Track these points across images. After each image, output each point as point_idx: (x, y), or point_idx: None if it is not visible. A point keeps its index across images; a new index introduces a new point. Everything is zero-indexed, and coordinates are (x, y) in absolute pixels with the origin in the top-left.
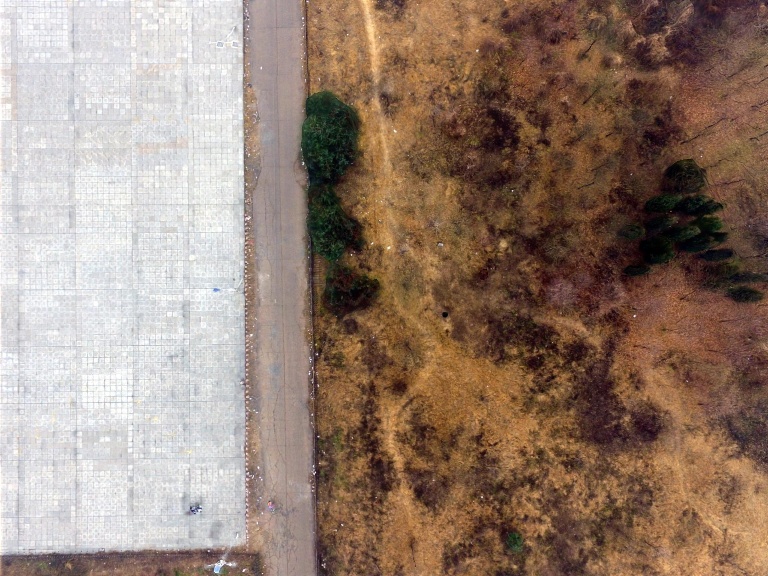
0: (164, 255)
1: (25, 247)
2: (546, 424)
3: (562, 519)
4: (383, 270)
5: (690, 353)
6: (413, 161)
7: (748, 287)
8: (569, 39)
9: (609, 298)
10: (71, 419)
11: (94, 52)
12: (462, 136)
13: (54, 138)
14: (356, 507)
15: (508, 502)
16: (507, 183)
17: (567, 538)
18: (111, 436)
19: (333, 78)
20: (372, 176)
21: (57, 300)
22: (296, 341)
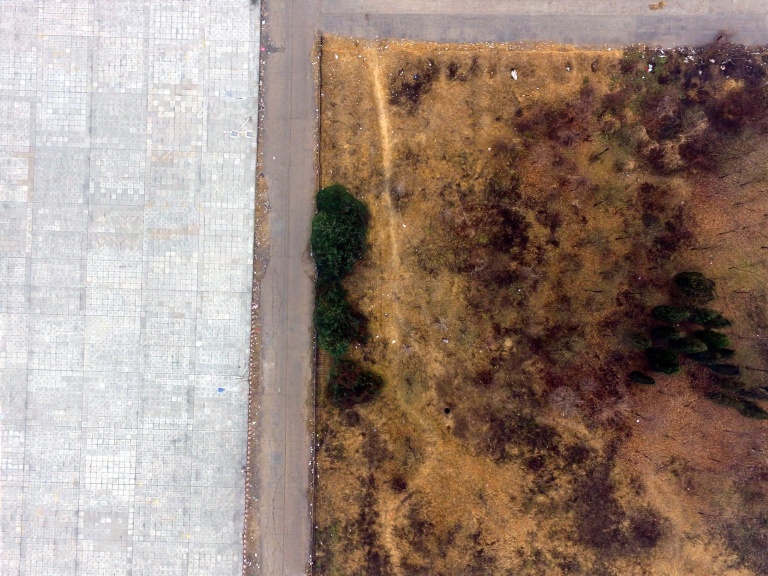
0: (171, 340)
1: (36, 327)
2: (544, 526)
3: None
4: (387, 363)
5: (692, 461)
6: (421, 256)
7: (754, 404)
8: (582, 140)
9: (613, 402)
10: (74, 499)
11: (110, 137)
12: None
13: (68, 221)
14: None
15: None
16: (514, 282)
17: None
18: (112, 517)
19: (345, 171)
20: (380, 269)
21: (65, 381)
22: (298, 430)
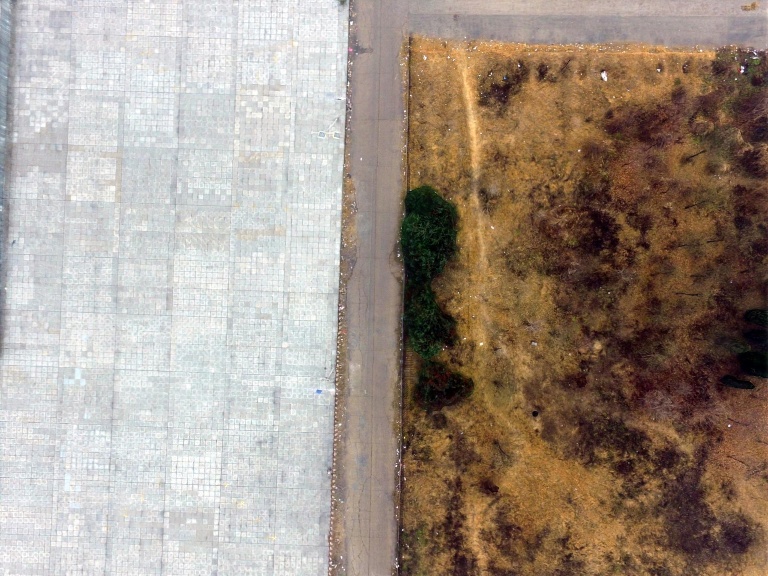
0: (257, 341)
1: (122, 327)
2: (634, 531)
3: None
4: (474, 366)
5: None
6: (509, 258)
7: None
8: (673, 142)
9: (704, 406)
10: (159, 499)
11: (198, 138)
12: None
13: (155, 221)
14: None
15: None
16: (604, 285)
17: None
18: (198, 518)
19: (433, 172)
20: (467, 271)
21: (151, 381)
22: (384, 433)
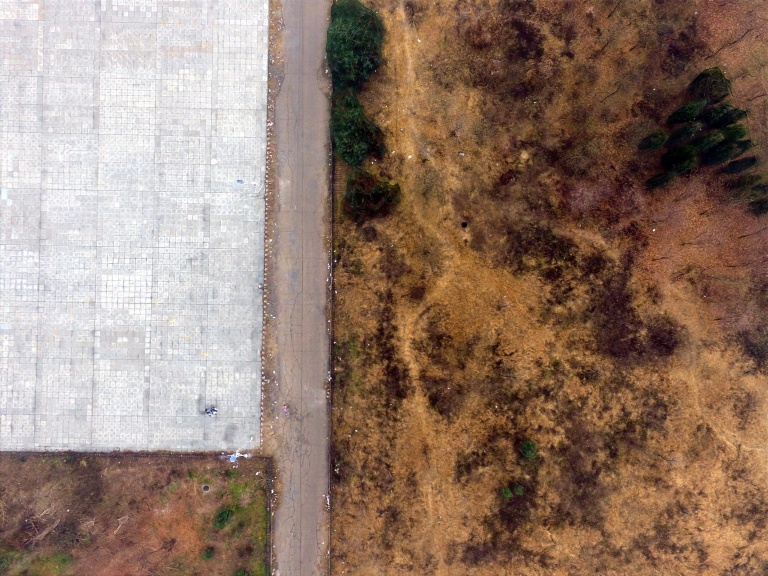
0: (186, 158)
1: (48, 146)
2: (562, 336)
3: (576, 431)
4: (403, 179)
5: (708, 269)
6: (436, 71)
7: None
8: None
9: (629, 212)
10: (90, 318)
11: None
12: (486, 46)
13: (80, 39)
14: (370, 413)
15: (522, 412)
16: (530, 95)
17: (580, 450)
18: (129, 336)
19: None
20: (395, 85)
21: (79, 200)
22: (315, 248)
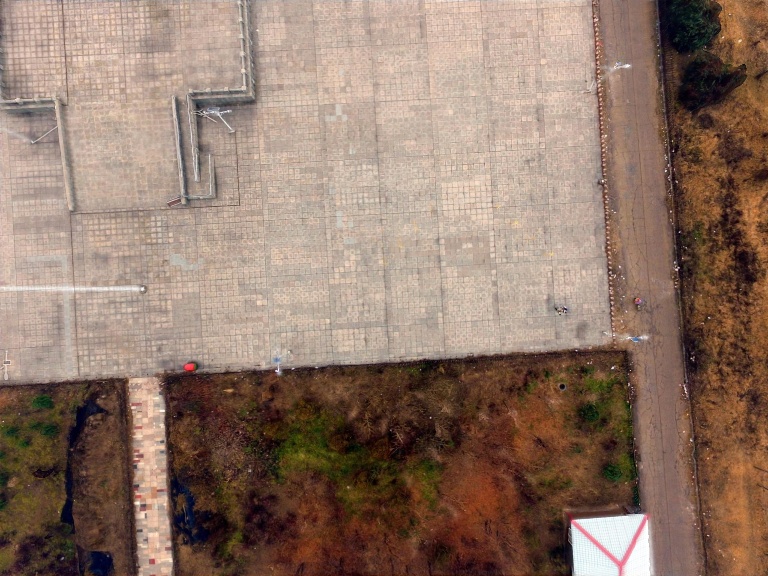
0: (516, 60)
1: (379, 59)
2: None
3: None
4: (735, 64)
5: None
6: None
7: None
8: None
9: None
10: (433, 227)
11: None
12: None
13: None
14: (722, 300)
15: None
16: None
17: None
18: (473, 242)
19: None
20: None
21: (413, 110)
22: (650, 140)
